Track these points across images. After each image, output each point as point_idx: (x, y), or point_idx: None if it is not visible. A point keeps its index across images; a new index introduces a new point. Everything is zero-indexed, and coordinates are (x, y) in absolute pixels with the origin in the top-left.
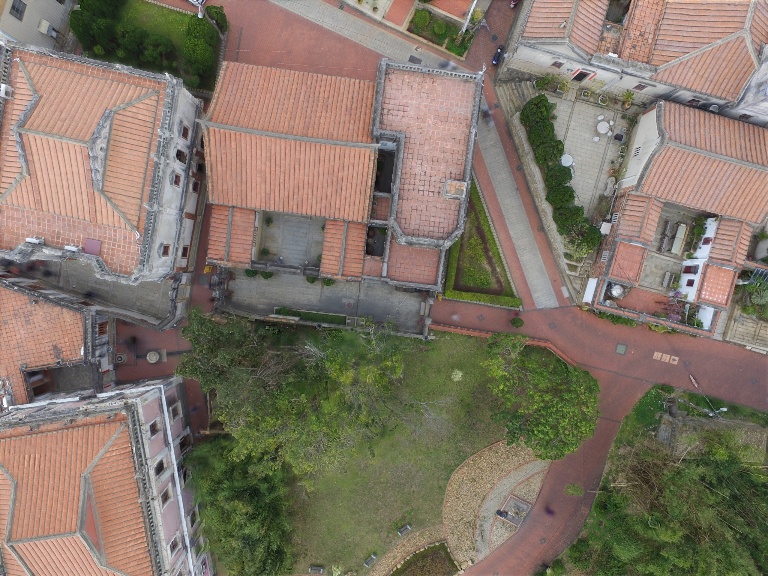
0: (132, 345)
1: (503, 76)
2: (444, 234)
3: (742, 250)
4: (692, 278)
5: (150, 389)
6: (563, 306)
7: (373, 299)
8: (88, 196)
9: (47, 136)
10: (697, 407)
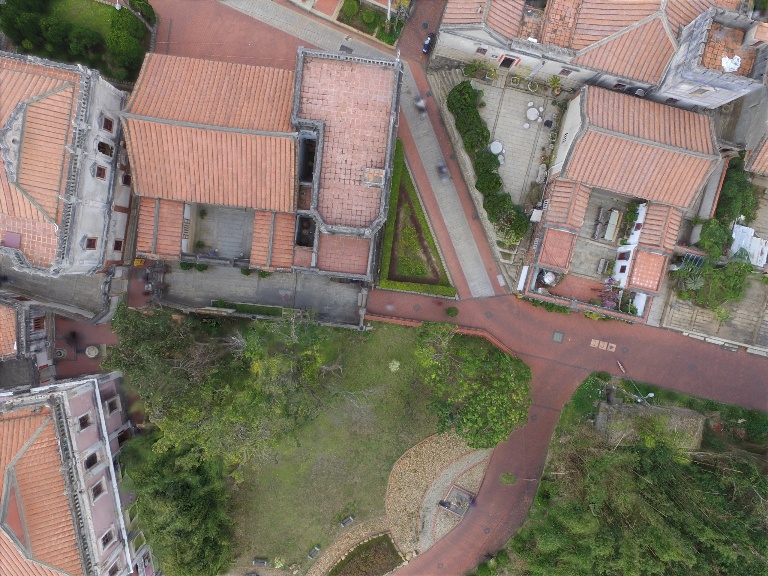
0: (72, 340)
1: (433, 64)
2: (366, 222)
3: (671, 235)
4: (624, 264)
5: (84, 383)
6: (499, 295)
7: (310, 290)
8: (4, 189)
9: None
10: (628, 393)
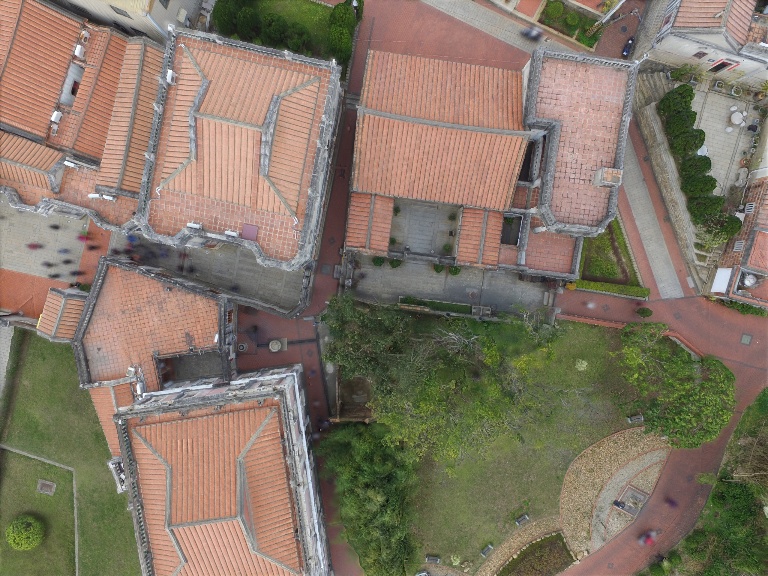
0: (253, 334)
1: None
2: (594, 222)
3: None
4: None
5: (283, 377)
6: (688, 296)
7: (496, 289)
8: (252, 181)
9: (223, 120)
10: None
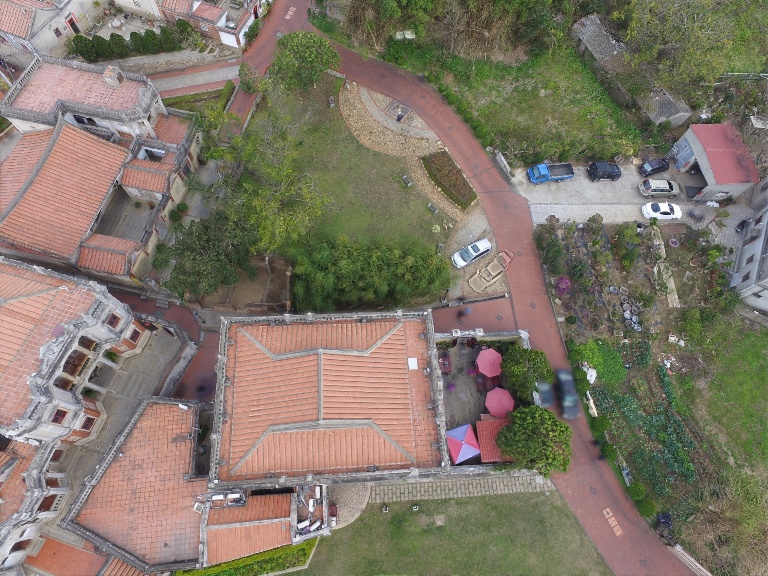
0: (205, 391)
1: None
2: None
3: None
4: None
5: None
6: (242, 62)
7: (209, 181)
8: (8, 316)
9: None
10: None
